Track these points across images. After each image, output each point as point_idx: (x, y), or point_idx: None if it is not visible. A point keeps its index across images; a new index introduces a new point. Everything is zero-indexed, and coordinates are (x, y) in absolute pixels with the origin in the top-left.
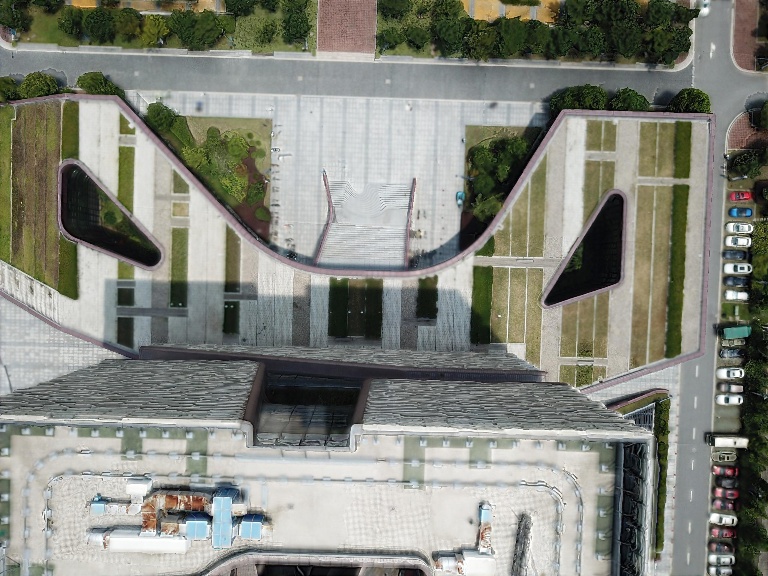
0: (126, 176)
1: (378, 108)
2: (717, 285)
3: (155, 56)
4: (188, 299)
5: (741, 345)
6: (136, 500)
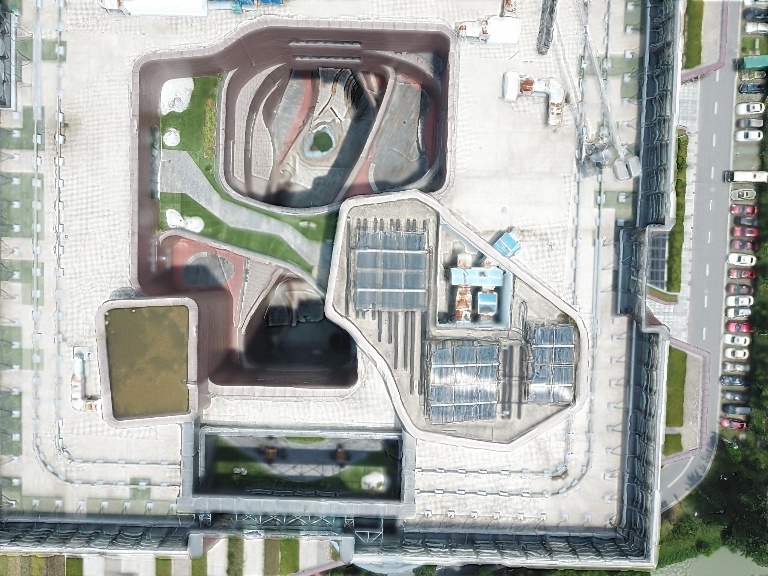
0: None
1: None
2: (737, 18)
3: None
4: None
5: (761, 78)
6: None
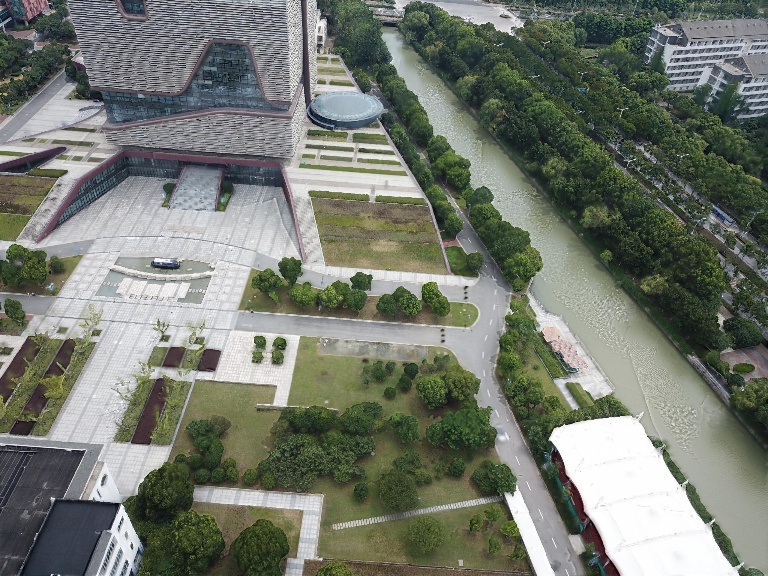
0: None
1: (38, 117)
2: None
3: None
4: None
5: None
6: None
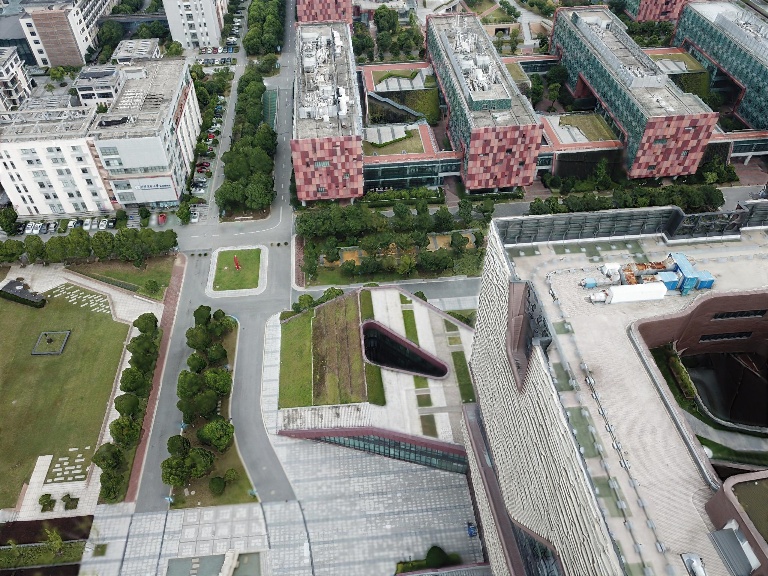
0: (410, 325)
1: None
2: None
3: (402, 285)
4: (476, 397)
5: None
6: (614, 273)
